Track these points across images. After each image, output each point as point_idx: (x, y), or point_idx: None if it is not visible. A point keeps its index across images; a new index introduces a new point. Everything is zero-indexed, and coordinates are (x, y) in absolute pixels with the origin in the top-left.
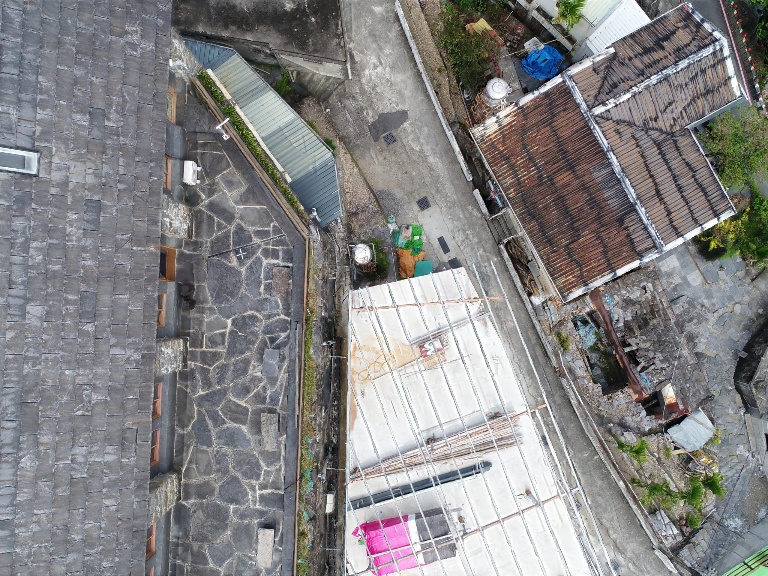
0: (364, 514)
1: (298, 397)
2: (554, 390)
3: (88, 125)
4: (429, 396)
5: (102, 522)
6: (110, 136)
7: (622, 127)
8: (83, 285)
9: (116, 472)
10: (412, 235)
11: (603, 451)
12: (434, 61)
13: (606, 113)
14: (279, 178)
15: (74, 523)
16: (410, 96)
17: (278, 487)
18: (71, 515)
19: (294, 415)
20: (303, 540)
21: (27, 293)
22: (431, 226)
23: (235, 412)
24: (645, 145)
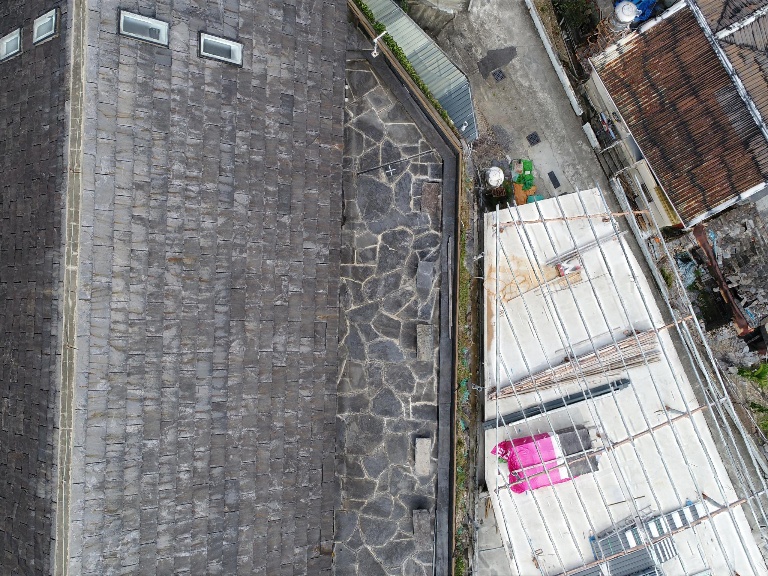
0: (503, 433)
1: (452, 309)
2: (665, 322)
3: (282, 20)
4: (578, 308)
5: (299, 412)
6: (300, 33)
7: (745, 51)
8: (280, 178)
9: (310, 364)
10: (523, 170)
11: (716, 381)
12: (537, 0)
13: (730, 37)
14: (429, 93)
15: (276, 411)
16: (518, 33)
17: (431, 399)
18: (273, 402)
19: (448, 327)
20: (460, 449)
21: (234, 181)
22: (541, 161)
23: (387, 326)
24: (767, 69)
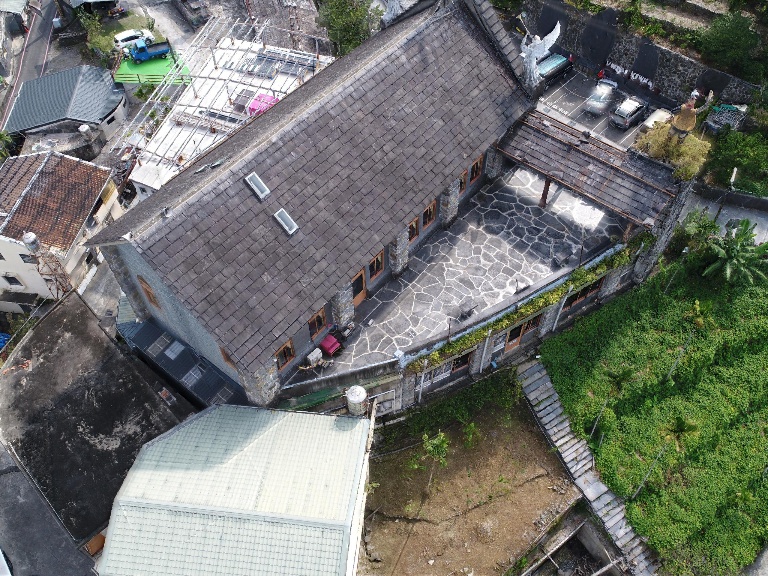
0: None
1: None
2: None
3: None
4: None
5: None
6: None
7: (5, 205)
8: None
9: None
10: None
11: None
12: None
13: (3, 212)
14: None
15: None
16: None
17: None
18: None
19: None
20: None
21: None
22: None
23: None
24: (6, 195)
